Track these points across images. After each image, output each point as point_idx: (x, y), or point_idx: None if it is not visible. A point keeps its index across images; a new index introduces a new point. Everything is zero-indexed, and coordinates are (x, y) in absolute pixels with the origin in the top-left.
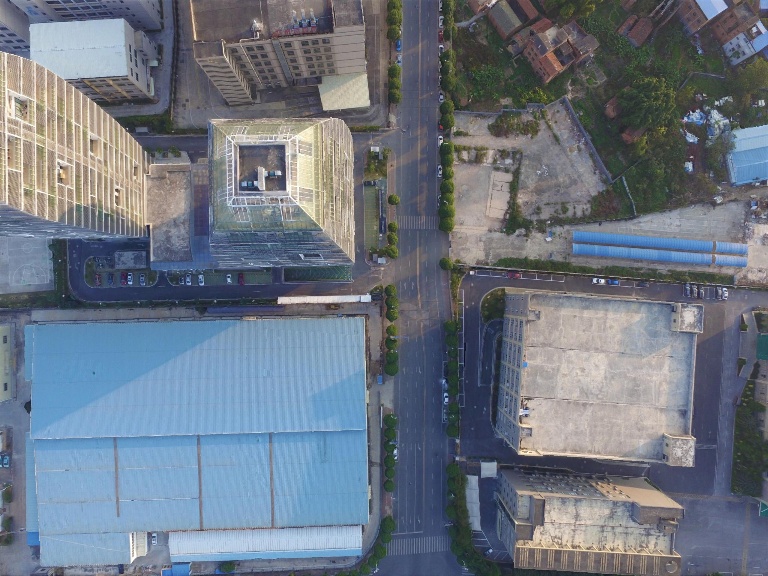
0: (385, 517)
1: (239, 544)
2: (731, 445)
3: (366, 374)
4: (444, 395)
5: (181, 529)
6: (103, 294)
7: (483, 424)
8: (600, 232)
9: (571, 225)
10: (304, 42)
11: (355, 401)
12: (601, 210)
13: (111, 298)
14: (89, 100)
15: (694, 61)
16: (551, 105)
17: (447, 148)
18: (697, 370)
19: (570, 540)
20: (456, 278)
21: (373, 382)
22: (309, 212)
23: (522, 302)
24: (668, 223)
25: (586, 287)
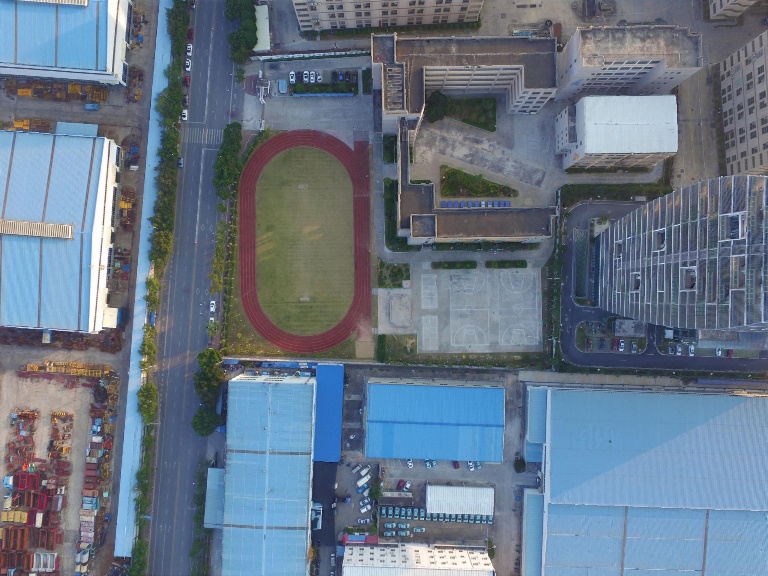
0: None
1: None
2: None
3: None
4: None
5: None
6: (592, 359)
7: None
8: None
9: None
10: None
11: None
12: None
13: (600, 363)
14: None
15: None
16: None
17: None
18: None
19: None
20: None
21: None
22: None
23: None
24: None
25: None
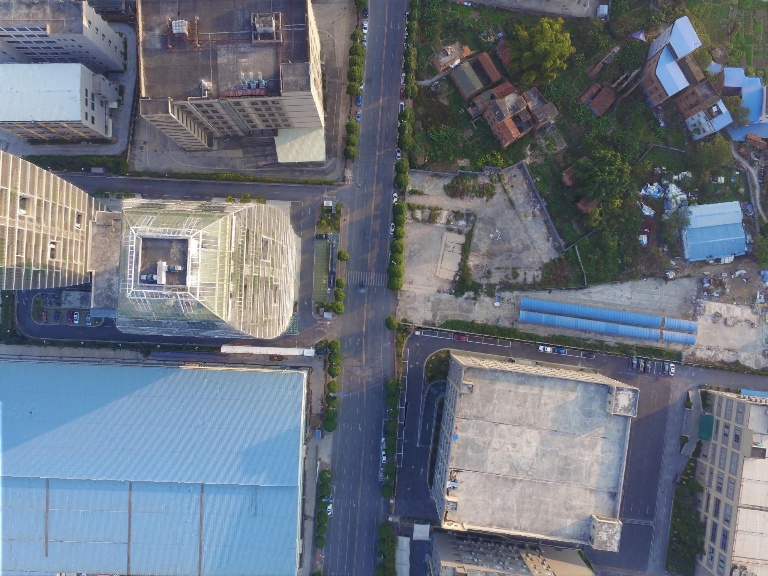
0: (314, 572)
1: None
2: (668, 522)
3: (305, 427)
4: (382, 453)
5: (108, 573)
6: (49, 331)
7: (419, 485)
8: (549, 300)
9: (520, 291)
10: (253, 102)
11: (289, 457)
12: (552, 278)
13: (56, 335)
14: (21, 161)
15: (655, 134)
16: (508, 169)
17: (398, 208)
18: (639, 445)
19: None
20: (401, 337)
21: (312, 435)
22: (210, 306)
23: (459, 372)
24: (619, 295)
25: (532, 354)
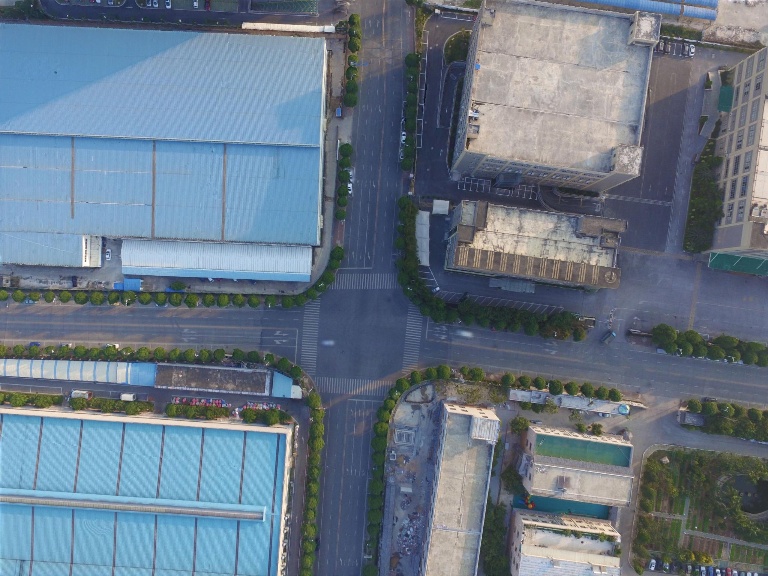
0: (335, 247)
1: (190, 260)
2: (687, 203)
3: (326, 108)
4: (402, 134)
5: (133, 235)
6: (71, 11)
7: (439, 166)
8: None
9: None
10: None
11: (310, 117)
12: None
13: (79, 16)
14: None
15: None
16: None
17: None
18: (658, 126)
19: (512, 251)
20: (421, 16)
21: (332, 117)
22: None
23: (480, 12)
24: None
25: None
